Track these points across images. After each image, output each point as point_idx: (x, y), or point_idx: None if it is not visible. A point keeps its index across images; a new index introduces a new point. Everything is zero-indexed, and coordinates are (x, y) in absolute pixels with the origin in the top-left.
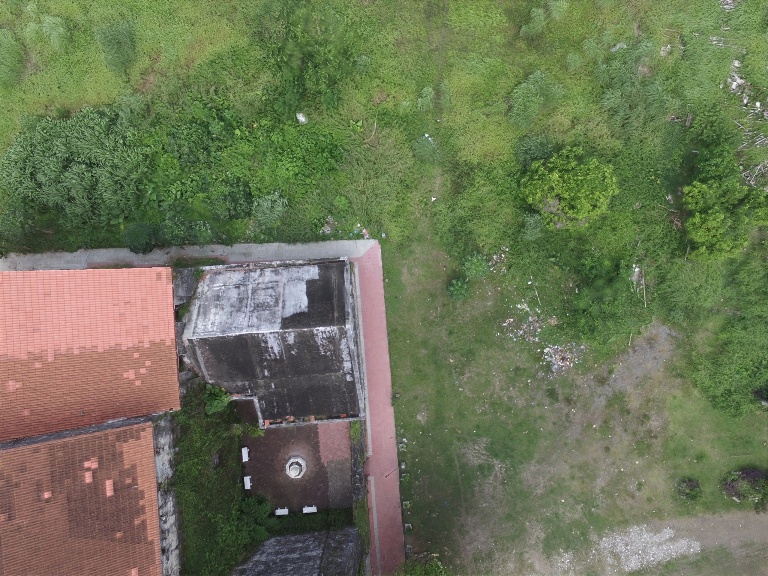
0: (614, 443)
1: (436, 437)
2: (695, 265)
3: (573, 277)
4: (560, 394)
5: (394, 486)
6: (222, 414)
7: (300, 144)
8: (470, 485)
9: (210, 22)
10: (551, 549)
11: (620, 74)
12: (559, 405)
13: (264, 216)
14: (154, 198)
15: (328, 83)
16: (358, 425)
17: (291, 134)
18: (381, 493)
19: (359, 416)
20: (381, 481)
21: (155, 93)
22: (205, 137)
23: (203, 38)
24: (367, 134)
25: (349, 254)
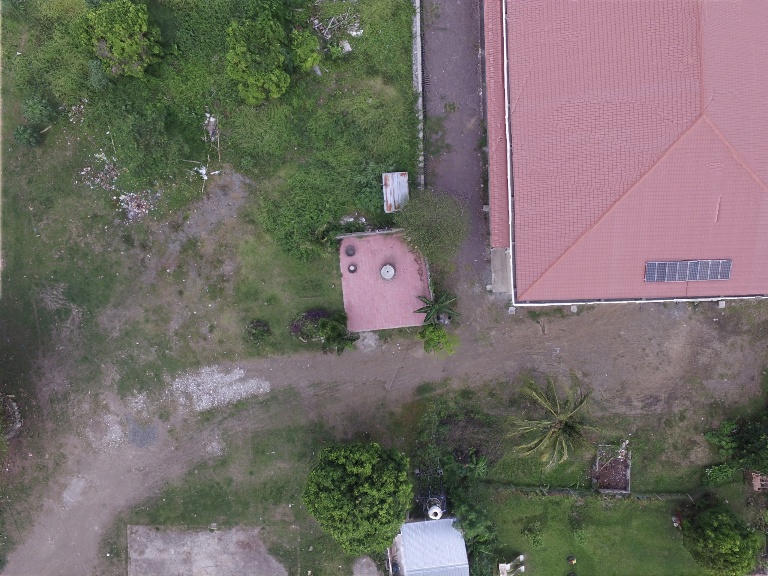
0: (188, 287)
1: (15, 282)
2: (261, 112)
3: None
4: (136, 240)
5: None
6: None
7: None
8: (47, 329)
9: None
10: (125, 390)
11: None
12: (135, 251)
13: None
14: None
15: None
16: None
17: None
18: None
19: None
20: None
21: None
22: None
23: None
24: None
25: None
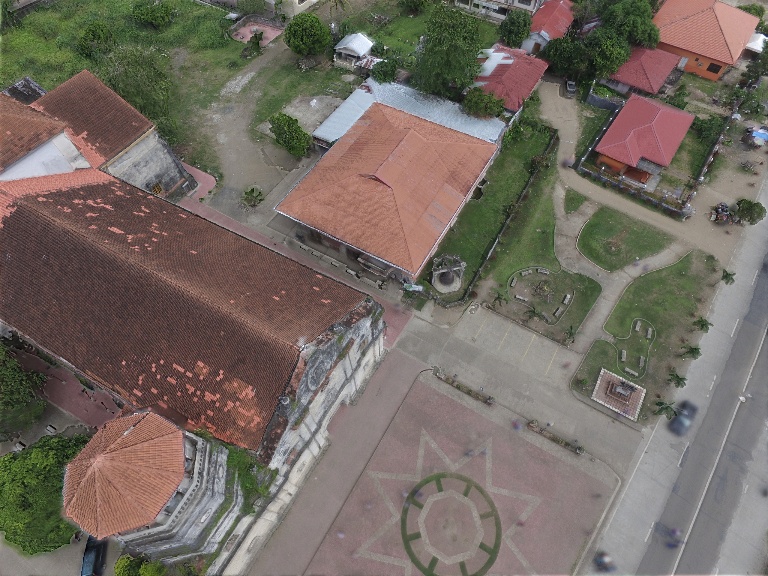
0: (193, 76)
1: None
2: None
3: None
4: None
5: None
6: None
7: None
8: None
9: None
10: (205, 107)
11: (89, 21)
12: None
13: None
14: None
15: None
16: None
17: None
18: None
19: None
20: None
21: None
22: None
23: None
24: None
25: None
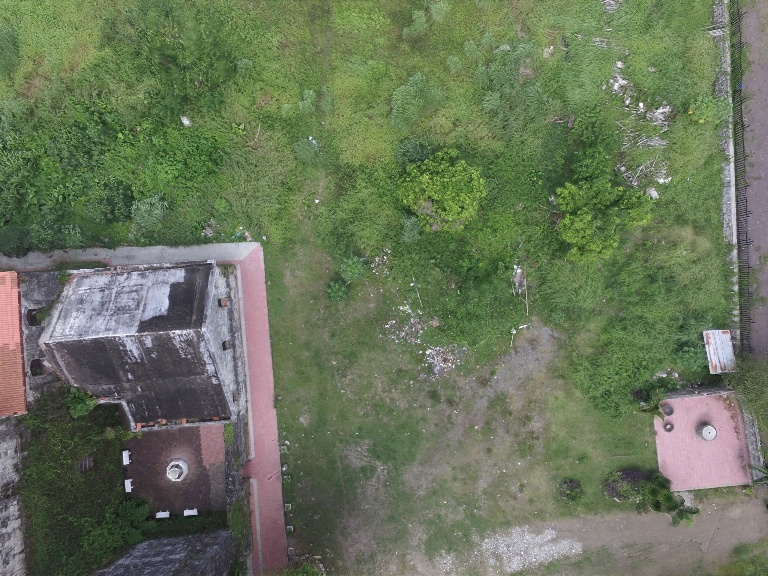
0: (496, 444)
1: (318, 439)
2: (575, 266)
3: (455, 279)
4: (442, 395)
5: (276, 488)
6: (96, 417)
7: (182, 147)
8: (352, 487)
9: (94, 26)
10: (433, 551)
11: (498, 76)
12: (441, 406)
13: (143, 219)
14: (35, 202)
15: (211, 86)
16: (231, 428)
17: (174, 137)
18: (263, 495)
19: (231, 419)
20: (263, 483)
21: (39, 97)
22: (85, 141)
23: (87, 42)
24: (250, 137)
25: (231, 257)
